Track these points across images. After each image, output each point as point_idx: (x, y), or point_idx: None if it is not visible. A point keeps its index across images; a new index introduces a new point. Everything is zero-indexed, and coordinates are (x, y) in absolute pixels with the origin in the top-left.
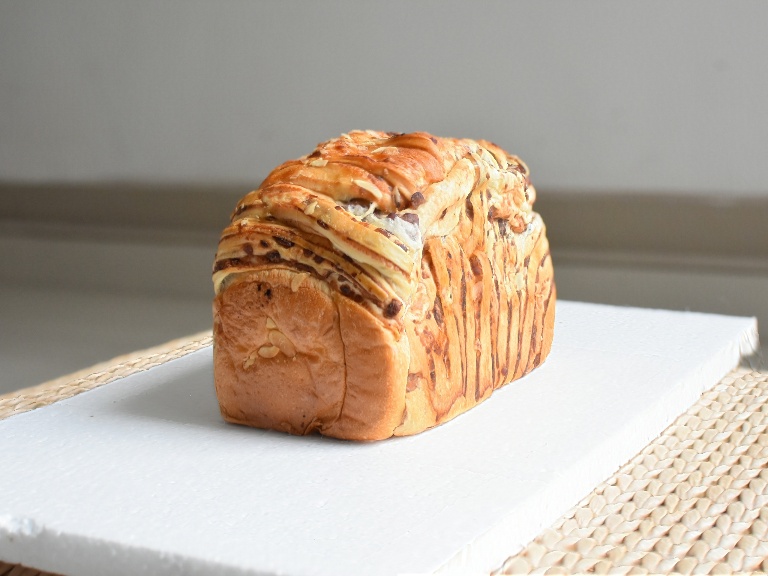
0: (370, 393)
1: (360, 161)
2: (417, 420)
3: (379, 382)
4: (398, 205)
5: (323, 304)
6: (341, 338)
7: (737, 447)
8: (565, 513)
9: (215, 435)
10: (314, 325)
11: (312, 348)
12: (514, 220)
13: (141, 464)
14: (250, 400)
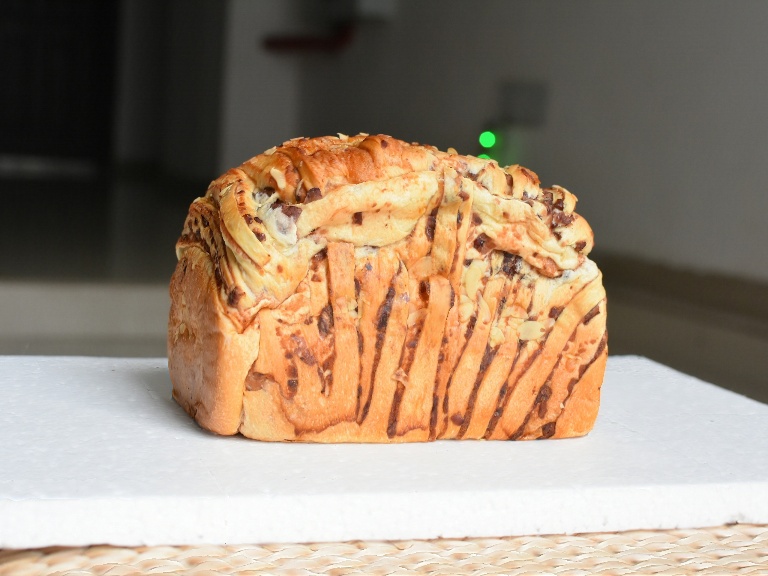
0: (208, 380)
1: (292, 152)
2: (258, 424)
3: (213, 370)
4: (298, 199)
5: (201, 284)
6: None
7: (618, 568)
8: (269, 543)
9: (141, 401)
10: (195, 304)
11: None
12: (533, 259)
13: (32, 398)
14: (175, 375)
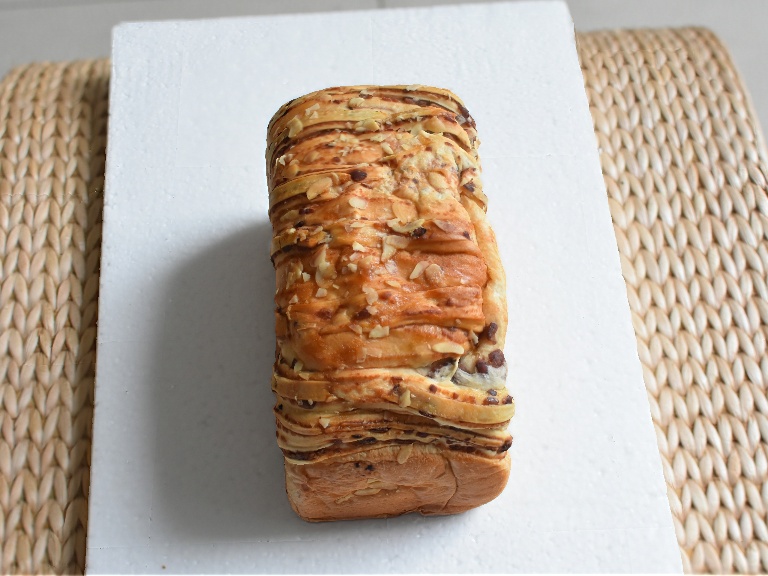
0: (483, 495)
1: (426, 319)
2: None
3: (493, 489)
4: None
5: (435, 464)
6: (454, 476)
7: (691, 292)
8: None
9: (322, 554)
10: (425, 476)
11: (420, 485)
12: None
13: None
14: None
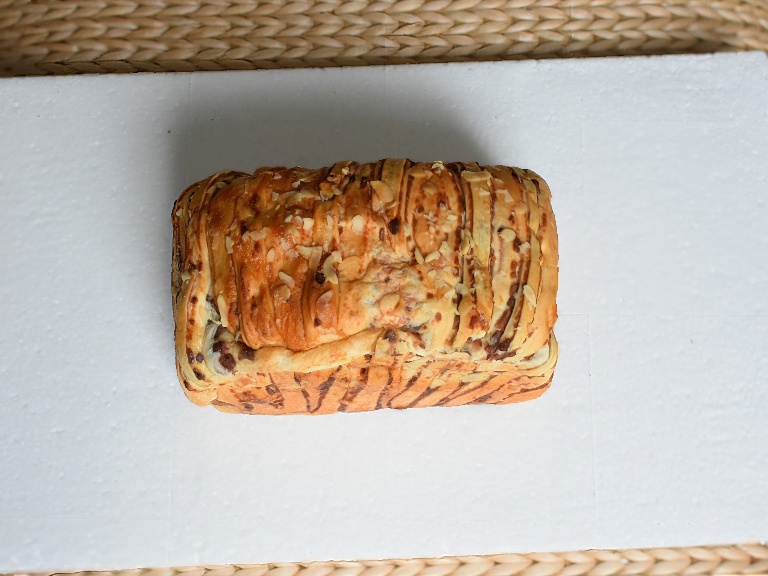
0: None
1: (238, 285)
2: None
3: None
4: None
5: None
6: None
7: None
8: (203, 565)
9: (170, 257)
10: None
11: None
12: None
13: (78, 256)
14: None
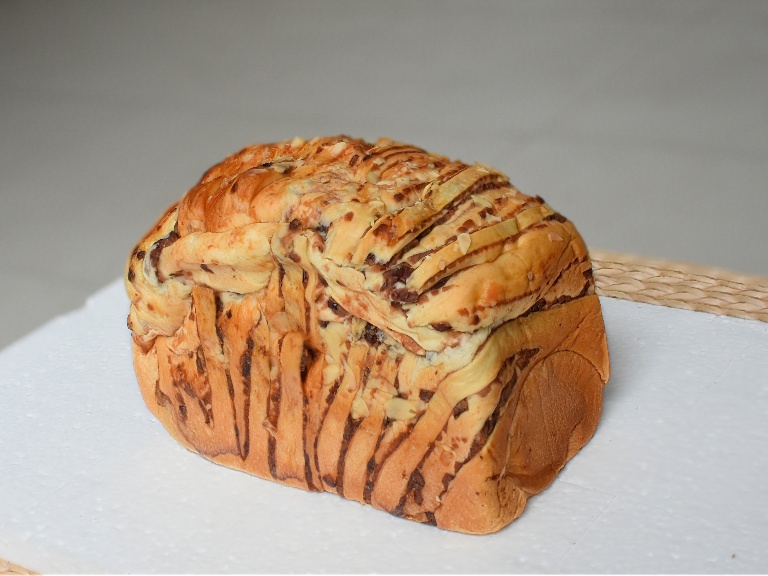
0: None
1: None
2: None
3: None
4: None
5: None
6: None
7: None
8: (35, 572)
9: None
10: None
11: None
12: (389, 332)
13: None
14: None
